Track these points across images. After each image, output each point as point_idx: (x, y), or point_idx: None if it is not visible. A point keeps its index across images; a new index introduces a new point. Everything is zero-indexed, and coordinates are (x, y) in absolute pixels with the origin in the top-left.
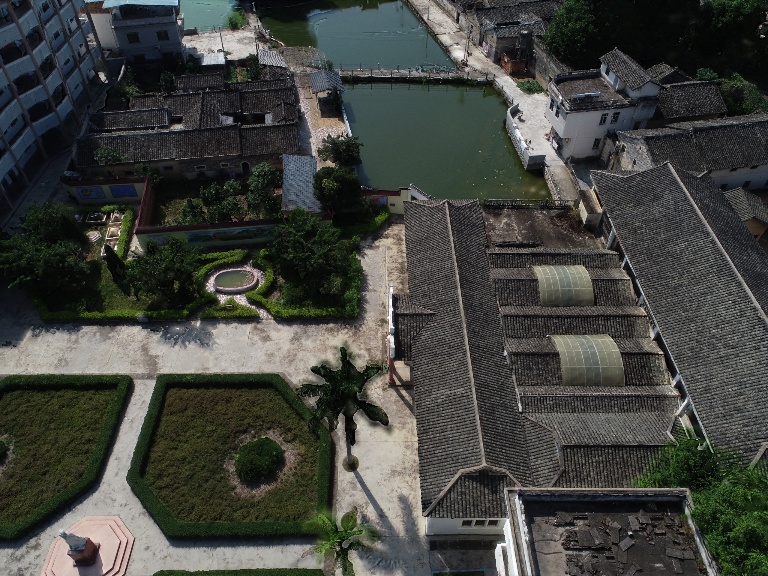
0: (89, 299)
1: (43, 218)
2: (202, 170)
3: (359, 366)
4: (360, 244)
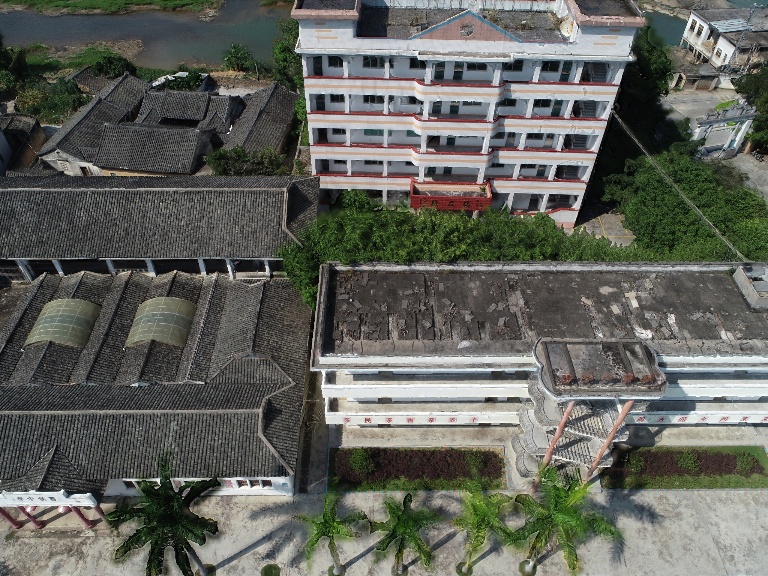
0: None
1: None
2: None
3: (73, 567)
4: None
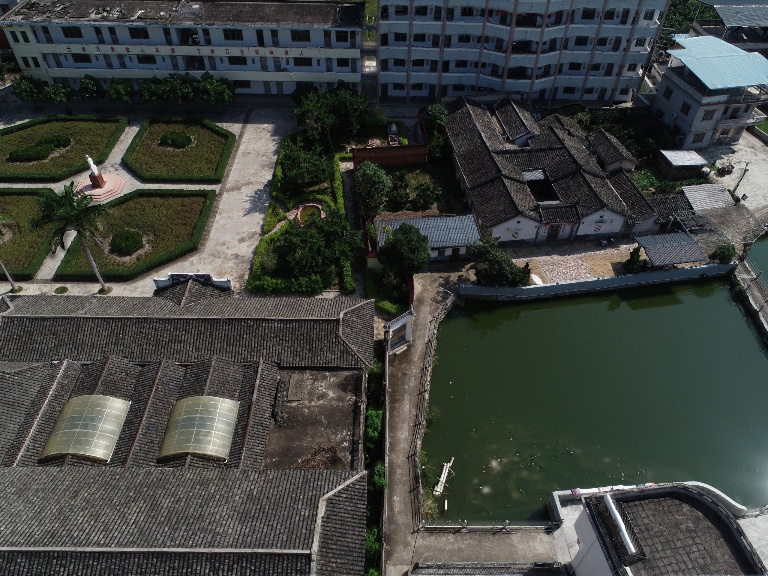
0: None
1: (343, 98)
2: None
3: None
4: (355, 295)
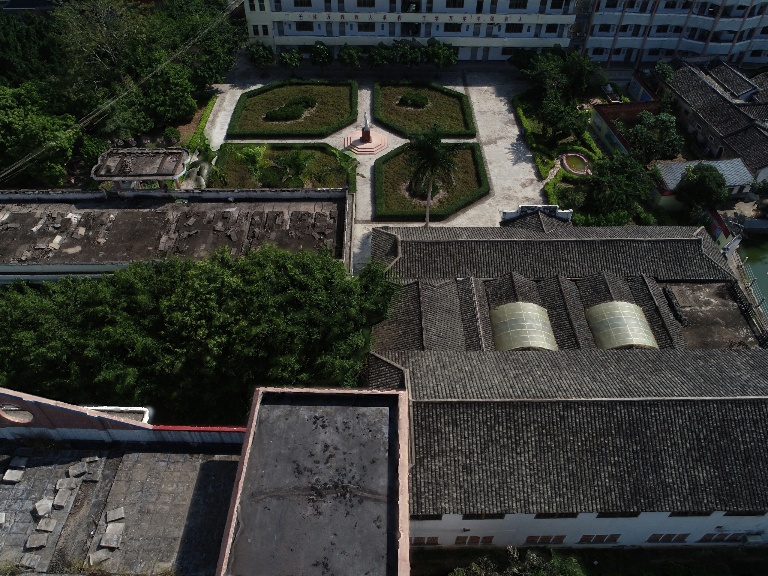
0: (536, 111)
1: (575, 59)
2: (698, 130)
3: None
4: None
